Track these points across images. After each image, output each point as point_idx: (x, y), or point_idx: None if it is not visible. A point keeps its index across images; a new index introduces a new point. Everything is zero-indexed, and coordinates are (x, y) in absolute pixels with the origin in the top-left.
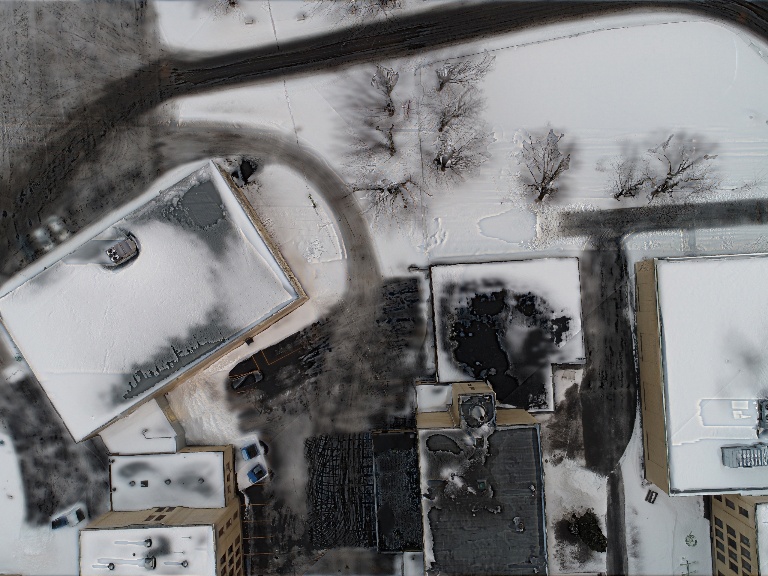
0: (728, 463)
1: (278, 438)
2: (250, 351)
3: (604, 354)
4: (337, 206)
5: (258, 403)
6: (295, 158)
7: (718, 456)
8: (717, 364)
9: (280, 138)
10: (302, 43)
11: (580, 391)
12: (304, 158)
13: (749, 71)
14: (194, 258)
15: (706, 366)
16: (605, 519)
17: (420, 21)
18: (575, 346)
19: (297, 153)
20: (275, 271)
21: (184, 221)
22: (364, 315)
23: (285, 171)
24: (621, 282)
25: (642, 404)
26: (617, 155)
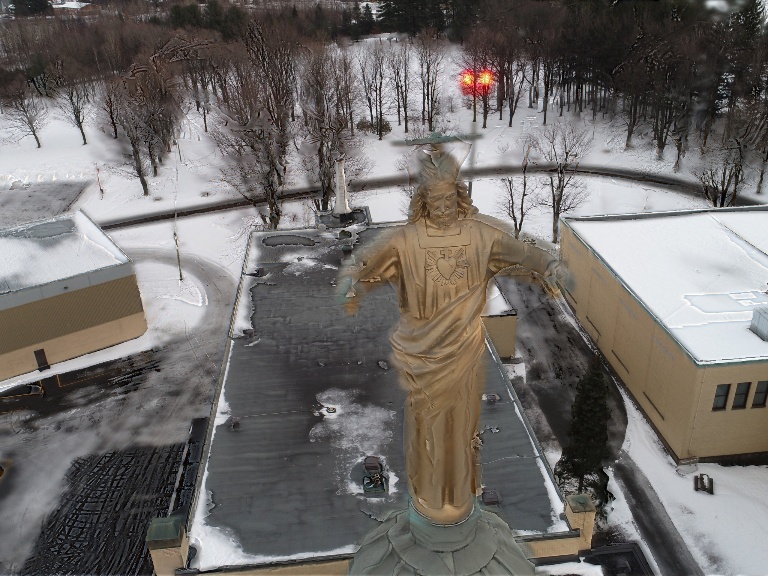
0: (764, 321)
1: (28, 459)
2: (39, 375)
3: (549, 351)
4: (207, 279)
5: (19, 423)
6: (171, 259)
7: (748, 332)
8: (684, 273)
9: (160, 251)
10: (202, 206)
11: (527, 382)
12: (181, 258)
13: (610, 188)
14: (16, 251)
15: (671, 274)
16: (634, 528)
17: (311, 190)
18: (496, 304)
19: (175, 257)
20: (110, 251)
21: (22, 236)
22: (216, 341)
23: (157, 264)
24: (546, 296)
25: (624, 381)
26: (507, 228)
